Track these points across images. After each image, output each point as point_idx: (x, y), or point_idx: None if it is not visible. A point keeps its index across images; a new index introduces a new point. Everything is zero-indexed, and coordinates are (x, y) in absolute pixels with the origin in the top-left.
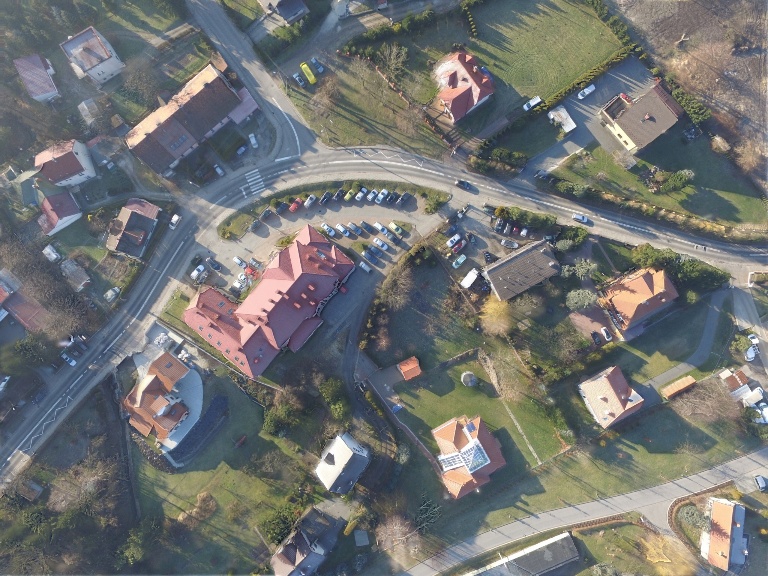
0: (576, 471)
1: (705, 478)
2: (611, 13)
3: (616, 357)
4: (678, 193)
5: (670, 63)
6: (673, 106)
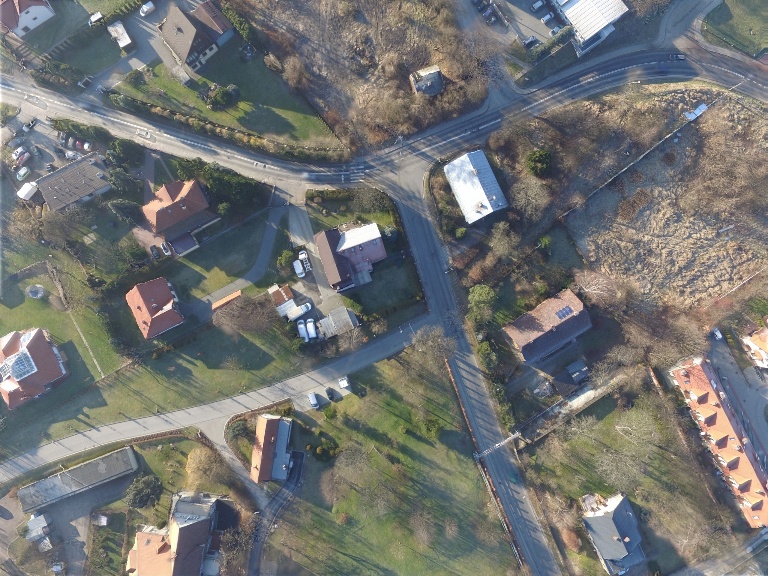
0: (138, 385)
1: (263, 395)
2: None
3: (177, 272)
4: (236, 110)
5: None
6: (221, 22)
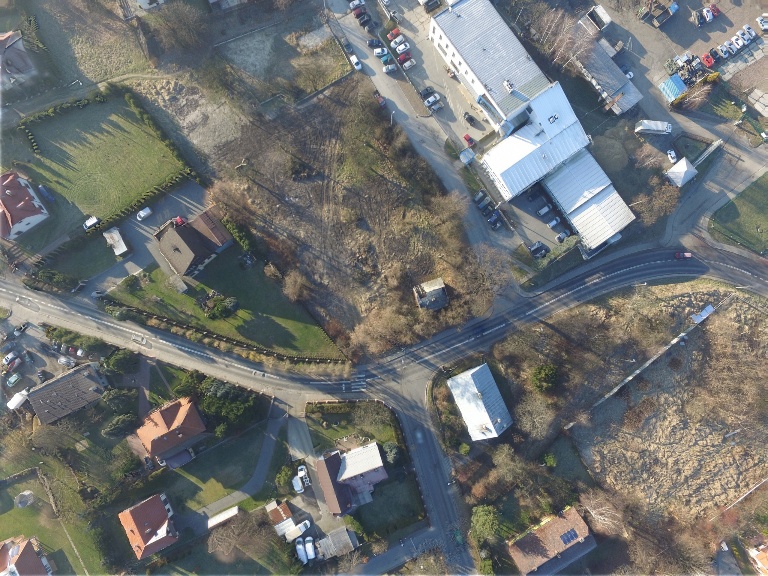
0: None
1: None
2: (172, 135)
3: (172, 482)
4: (235, 318)
5: (229, 187)
6: (220, 233)
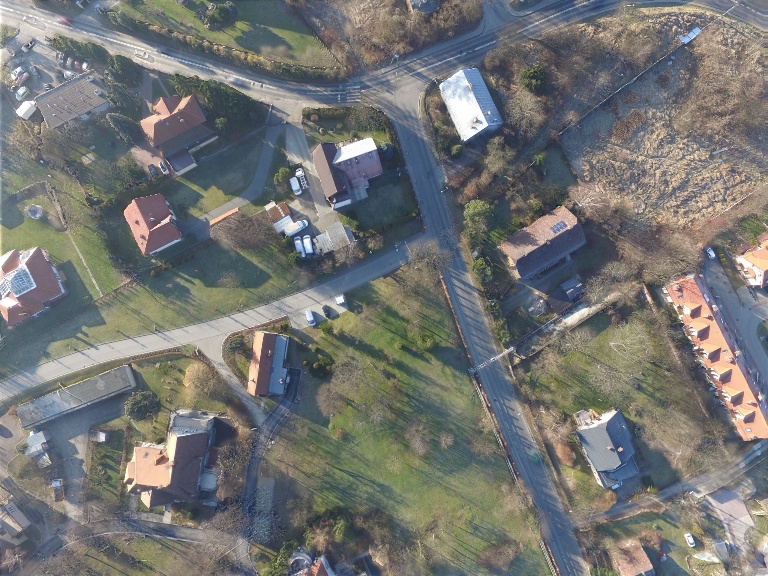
0: (136, 304)
1: (261, 313)
2: None
3: (174, 191)
4: (234, 30)
5: None
6: None
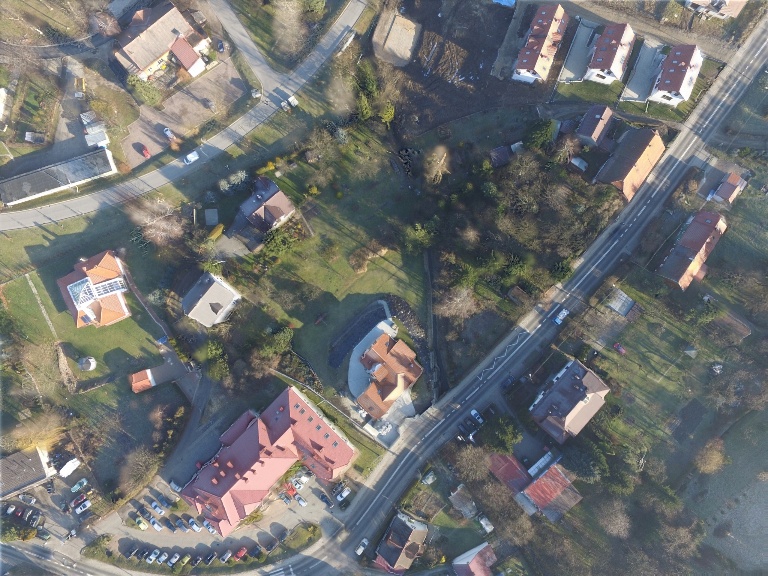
0: None
1: None
2: None
3: None
4: None
5: None
6: None
